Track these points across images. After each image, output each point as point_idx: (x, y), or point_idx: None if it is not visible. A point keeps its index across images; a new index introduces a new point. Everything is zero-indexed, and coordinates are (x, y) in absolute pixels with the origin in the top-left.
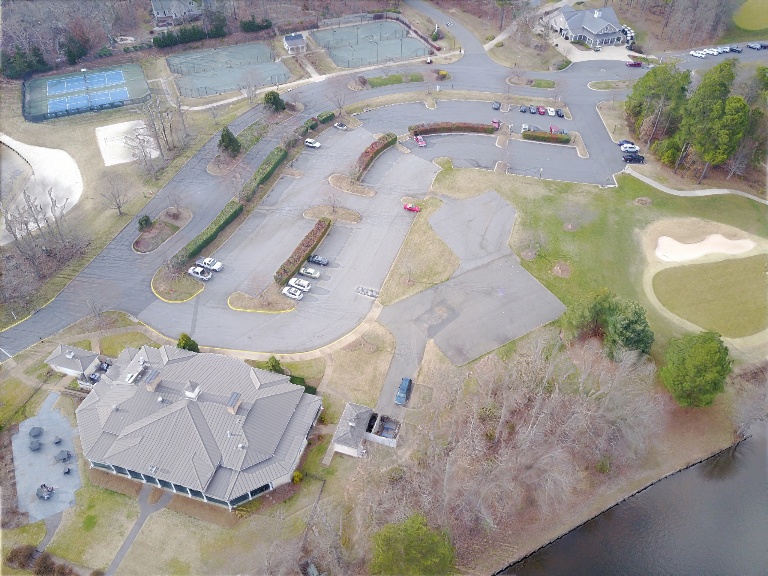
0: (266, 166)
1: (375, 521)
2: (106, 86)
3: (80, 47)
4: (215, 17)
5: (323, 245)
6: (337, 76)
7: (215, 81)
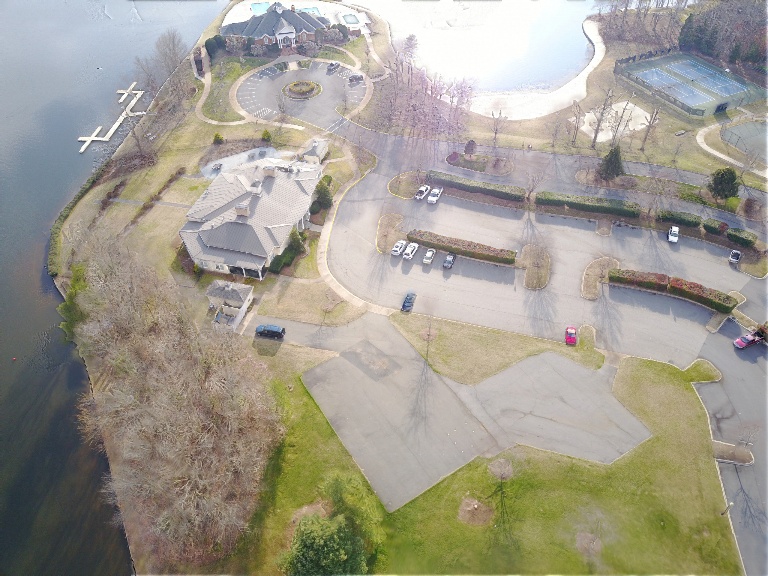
0: (595, 201)
1: None
2: (708, 89)
3: (754, 52)
4: None
5: (478, 263)
6: None
7: None
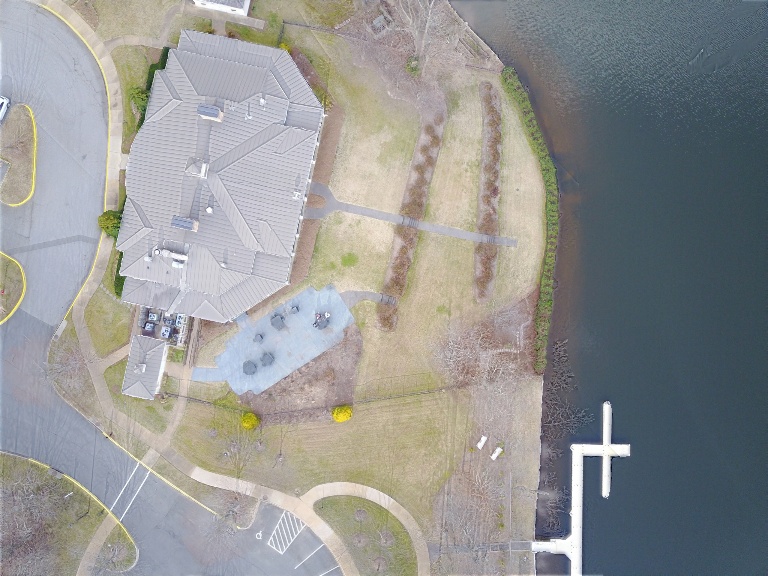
0: None
1: None
2: None
3: None
4: None
5: None
6: None
7: None
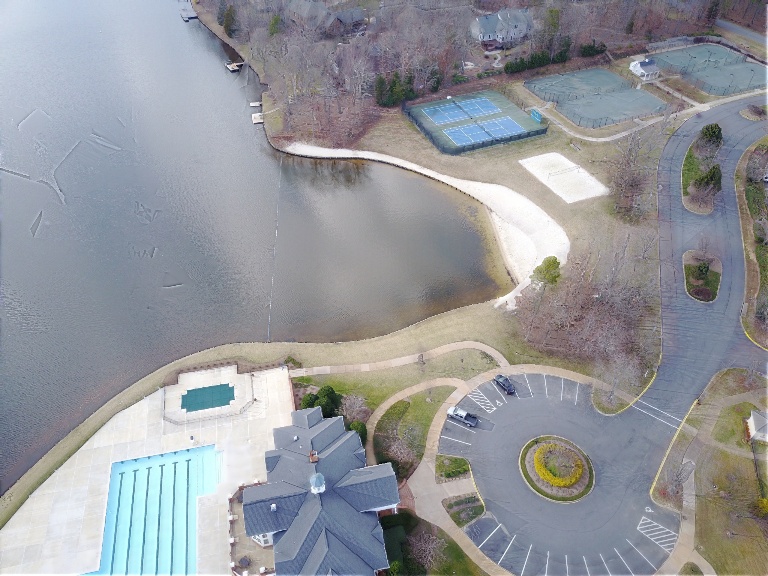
0: (759, 205)
1: None
2: (487, 115)
3: (441, 74)
4: (564, 42)
5: None
6: (720, 105)
7: (597, 110)
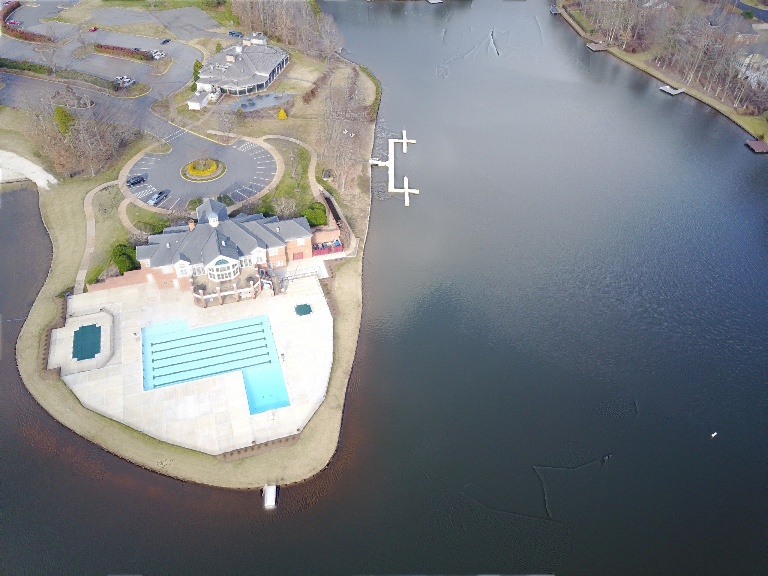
0: (15, 62)
1: (309, 4)
2: None
3: None
4: None
5: None
6: None
7: None
